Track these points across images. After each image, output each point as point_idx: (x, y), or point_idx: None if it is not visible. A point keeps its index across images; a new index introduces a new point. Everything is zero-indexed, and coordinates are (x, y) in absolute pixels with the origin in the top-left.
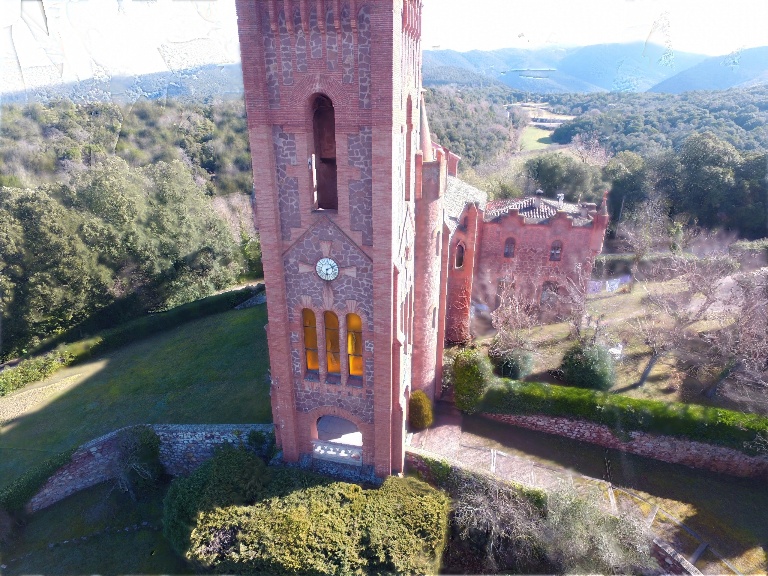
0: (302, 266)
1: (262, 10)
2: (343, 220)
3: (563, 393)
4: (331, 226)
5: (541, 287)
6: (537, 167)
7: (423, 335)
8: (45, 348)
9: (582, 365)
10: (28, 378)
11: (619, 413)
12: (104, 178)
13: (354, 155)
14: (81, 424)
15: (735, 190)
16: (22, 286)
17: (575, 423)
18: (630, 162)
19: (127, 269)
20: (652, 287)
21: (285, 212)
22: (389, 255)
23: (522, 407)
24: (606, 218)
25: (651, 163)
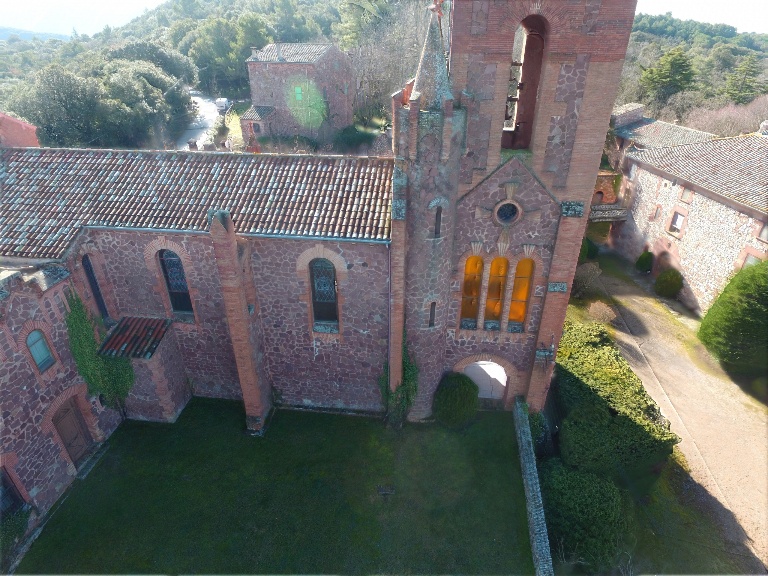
0: None
1: None
2: None
3: None
4: None
5: None
6: None
7: None
8: None
9: None
10: None
11: None
12: None
13: None
14: None
15: (135, 118)
16: None
17: None
18: None
19: None
20: None
21: None
22: None
23: None
24: None
25: (27, 107)
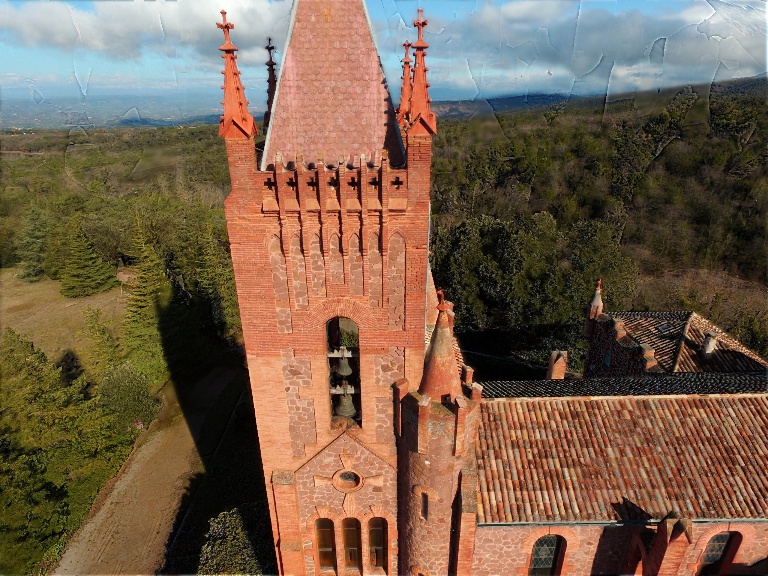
0: None
1: None
2: None
3: None
4: None
5: None
6: None
7: None
8: None
9: None
10: None
11: None
12: None
13: None
14: None
15: None
16: None
17: None
18: None
19: (496, 311)
20: None
21: None
22: None
23: None
24: None
25: None
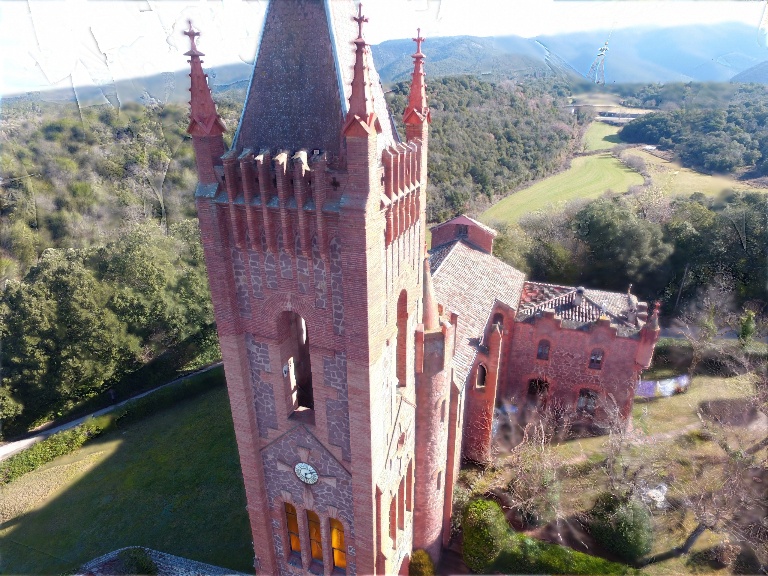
0: (280, 465)
1: (228, 224)
2: (321, 433)
3: (586, 568)
4: (309, 435)
5: (578, 394)
6: (588, 223)
7: (426, 499)
8: (79, 410)
9: (613, 529)
10: (56, 452)
11: None
12: (138, 243)
13: (330, 376)
14: (92, 525)
15: None
16: (56, 358)
17: None
18: (699, 216)
19: (155, 336)
20: (713, 385)
21: (261, 412)
22: (369, 481)
23: (538, 574)
24: (656, 332)
25: (723, 221)
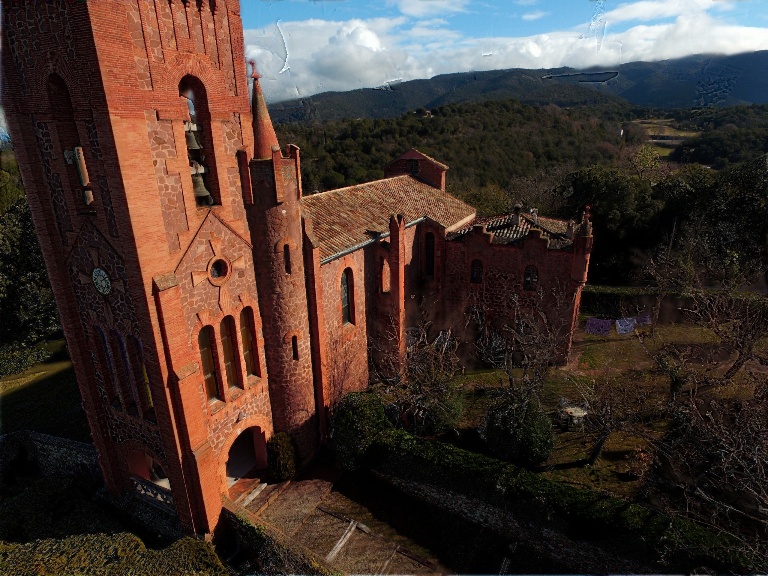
0: (82, 276)
1: None
2: (102, 224)
3: (460, 461)
4: (95, 231)
5: None
6: (572, 182)
7: (281, 368)
8: None
9: (500, 426)
10: (4, 370)
11: (526, 499)
12: None
13: (95, 146)
14: (4, 422)
15: None
16: (17, 284)
17: (475, 502)
18: (700, 177)
19: None
20: (687, 332)
21: (59, 213)
22: (138, 267)
23: (413, 471)
24: (588, 240)
25: (723, 178)
